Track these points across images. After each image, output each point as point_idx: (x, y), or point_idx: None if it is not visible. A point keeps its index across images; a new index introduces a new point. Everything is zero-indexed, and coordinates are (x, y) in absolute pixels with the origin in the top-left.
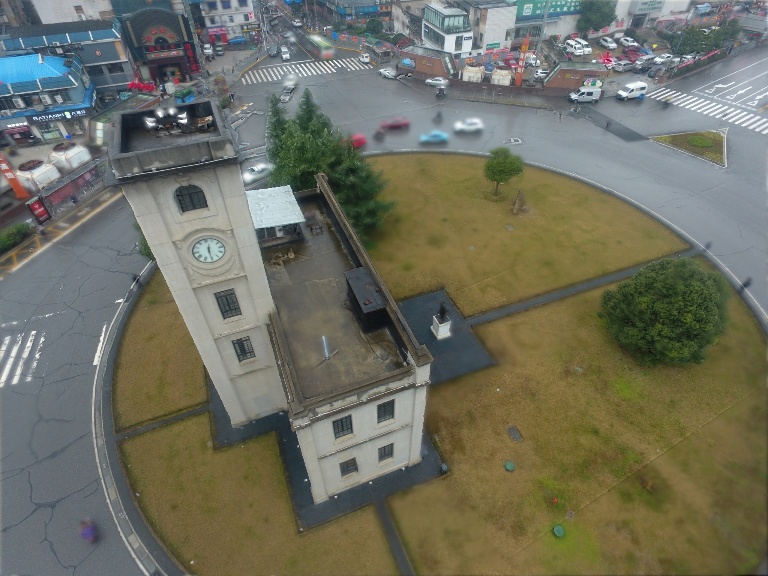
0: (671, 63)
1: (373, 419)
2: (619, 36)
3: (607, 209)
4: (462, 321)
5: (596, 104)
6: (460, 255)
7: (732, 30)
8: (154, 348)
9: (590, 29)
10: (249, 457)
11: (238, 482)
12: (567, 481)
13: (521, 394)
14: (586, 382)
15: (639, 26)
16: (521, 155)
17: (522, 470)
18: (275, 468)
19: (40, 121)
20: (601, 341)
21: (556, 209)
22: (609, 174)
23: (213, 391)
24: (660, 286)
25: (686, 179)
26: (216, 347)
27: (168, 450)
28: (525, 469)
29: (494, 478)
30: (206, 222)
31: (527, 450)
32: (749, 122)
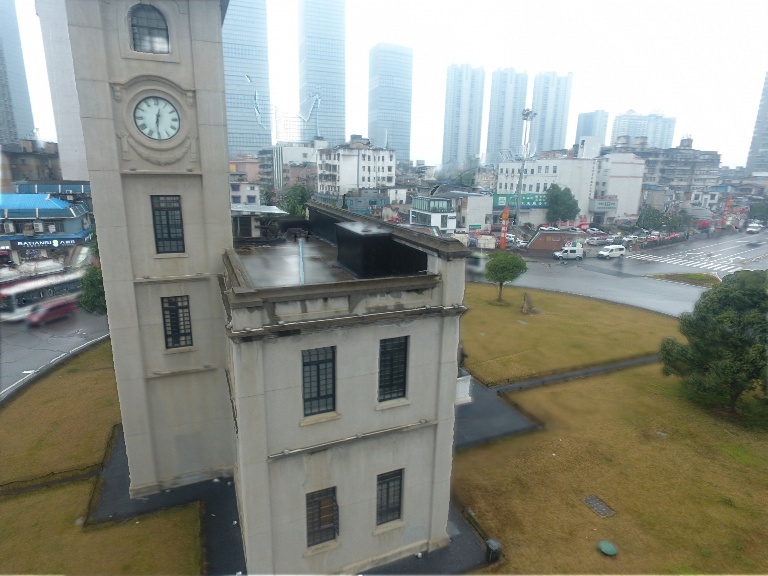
0: (639, 240)
1: (372, 379)
2: (585, 228)
3: (625, 312)
4: (484, 389)
5: (581, 261)
6: (470, 338)
7: (684, 218)
8: (50, 409)
9: (559, 220)
10: (143, 536)
11: (109, 574)
12: (719, 571)
13: (590, 459)
14: (680, 446)
15: (600, 222)
16: (519, 284)
17: (631, 554)
18: (186, 554)
19: (24, 247)
20: (677, 407)
21: (569, 311)
22: (615, 294)
23: (116, 454)
24: (739, 294)
25: (697, 297)
26: (135, 301)
27: (2, 527)
28: (636, 553)
29: (586, 567)
30: (162, 70)
31: (628, 527)
32: (734, 270)
